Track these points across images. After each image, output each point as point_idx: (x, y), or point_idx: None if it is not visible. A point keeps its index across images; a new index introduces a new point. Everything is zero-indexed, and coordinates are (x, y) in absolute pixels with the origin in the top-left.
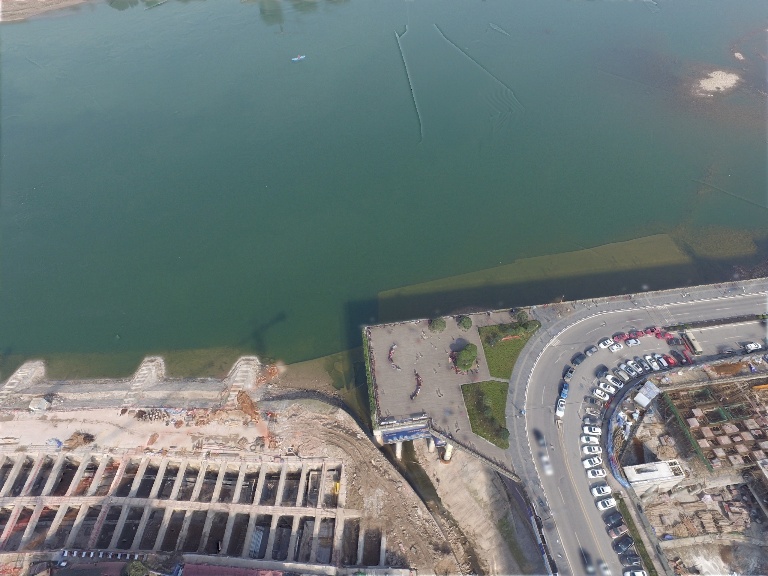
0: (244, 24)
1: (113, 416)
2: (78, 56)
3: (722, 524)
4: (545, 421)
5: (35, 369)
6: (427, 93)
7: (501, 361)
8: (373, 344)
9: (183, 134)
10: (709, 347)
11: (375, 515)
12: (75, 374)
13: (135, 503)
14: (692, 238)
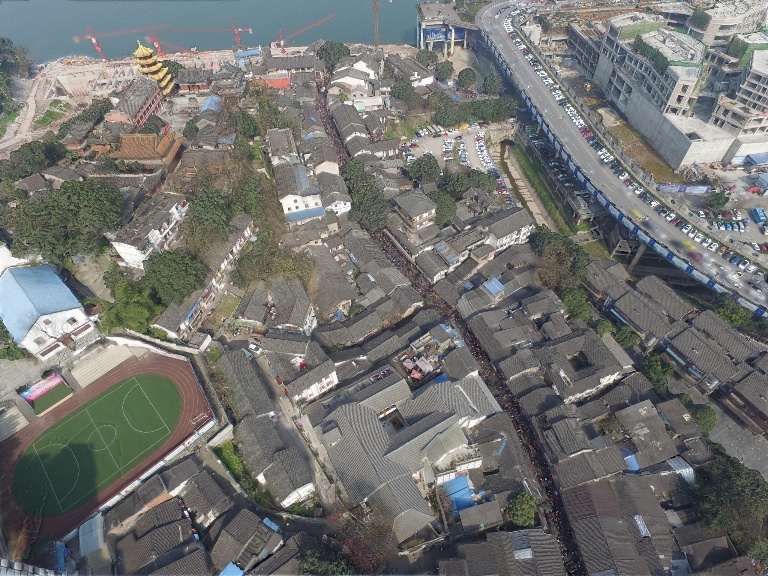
0: None
1: None
2: None
3: None
4: None
5: None
6: None
7: (474, 8)
8: (421, 6)
9: None
10: None
11: None
12: None
13: None
14: None
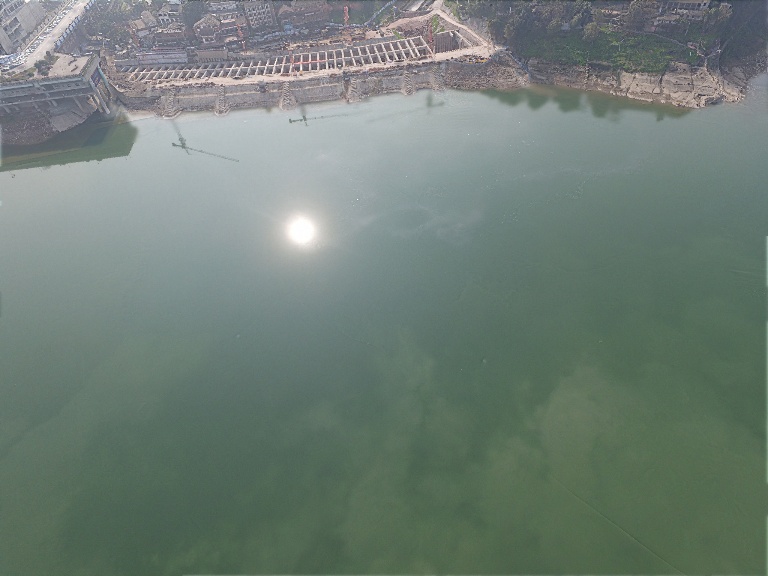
0: None
1: None
2: (522, 556)
3: None
4: None
5: (283, 105)
6: None
7: None
8: None
9: (220, 283)
10: None
11: None
12: (263, 108)
13: None
14: None
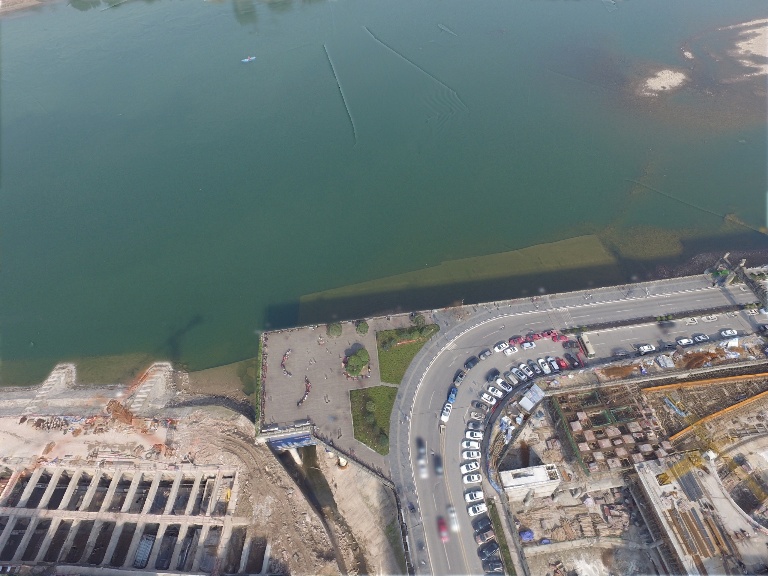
0: (199, 25)
1: (11, 425)
2: (28, 58)
3: (600, 527)
4: (429, 426)
5: None
6: (358, 95)
7: (394, 366)
8: (268, 350)
9: (124, 137)
10: (604, 349)
11: (263, 522)
12: None
13: (22, 513)
14: (620, 238)
